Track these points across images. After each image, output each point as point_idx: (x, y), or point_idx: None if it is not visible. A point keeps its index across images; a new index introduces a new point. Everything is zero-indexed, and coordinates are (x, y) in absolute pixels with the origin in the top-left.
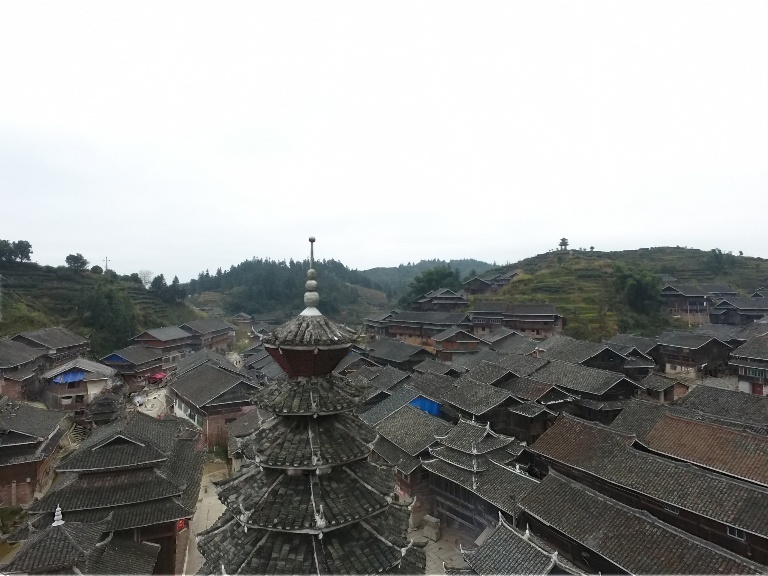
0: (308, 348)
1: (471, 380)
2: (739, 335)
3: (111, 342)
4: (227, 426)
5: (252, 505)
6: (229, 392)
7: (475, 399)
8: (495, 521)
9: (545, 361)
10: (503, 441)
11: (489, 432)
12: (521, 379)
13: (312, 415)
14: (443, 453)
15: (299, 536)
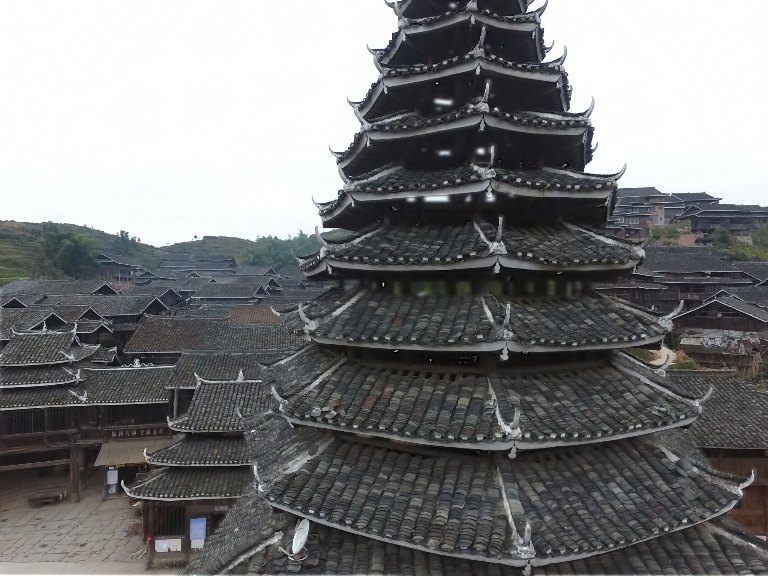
0: None
1: None
2: (185, 287)
3: None
4: None
5: None
6: None
7: None
8: (124, 426)
9: (40, 296)
10: (89, 349)
11: (75, 338)
12: None
13: None
14: None
15: None
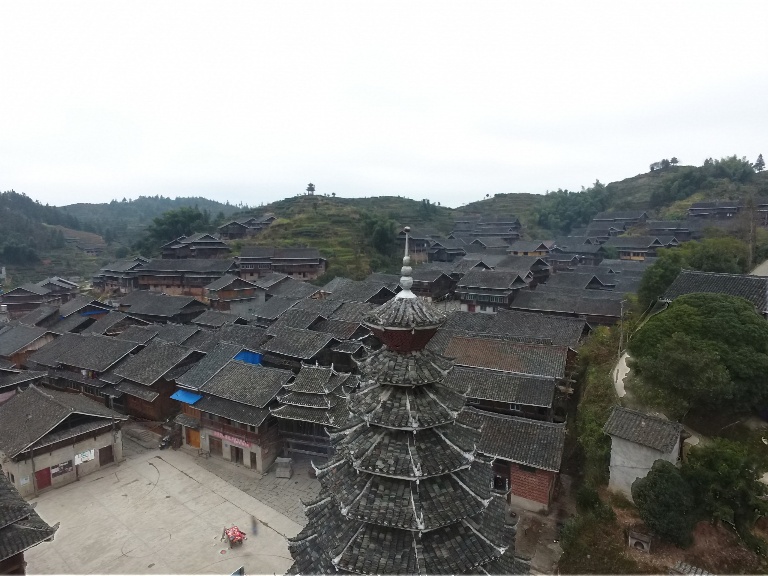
0: (434, 327)
1: (288, 328)
2: (456, 270)
3: None
4: None
5: (419, 462)
6: None
7: (299, 345)
8: None
9: (340, 303)
10: (343, 378)
11: (333, 372)
12: (329, 321)
13: (441, 380)
14: (293, 399)
15: (438, 476)
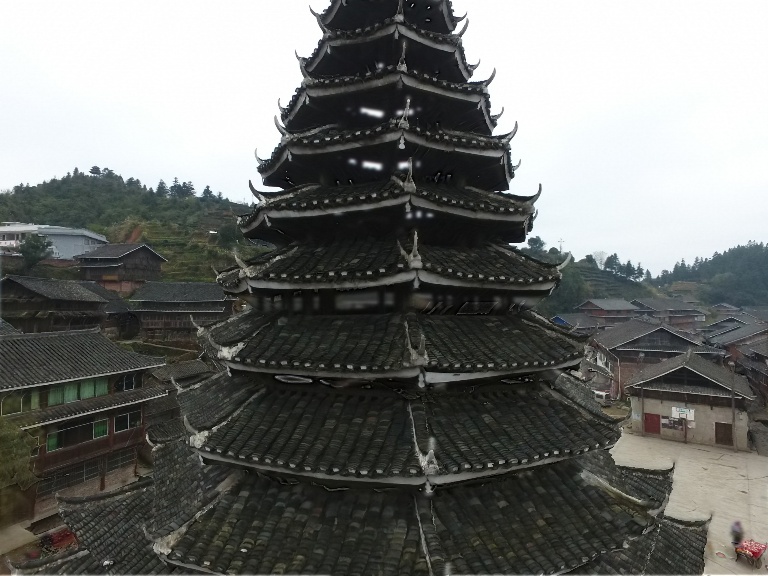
0: None
1: None
2: None
3: (559, 310)
4: (637, 371)
5: None
6: (646, 339)
7: None
8: None
9: None
10: None
11: None
12: None
13: (342, 3)
14: None
15: None
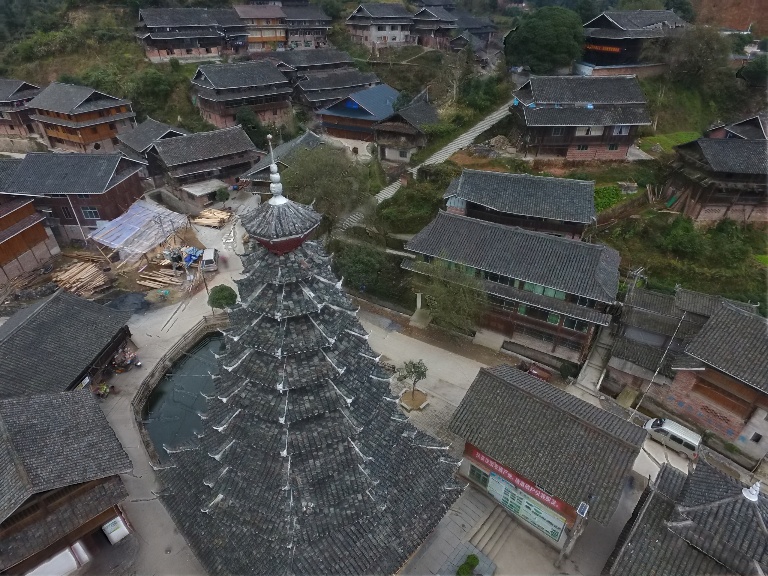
0: None
1: None
2: None
3: None
4: None
5: None
6: None
7: None
8: None
9: None
10: None
11: None
12: None
13: None
14: None
15: None
